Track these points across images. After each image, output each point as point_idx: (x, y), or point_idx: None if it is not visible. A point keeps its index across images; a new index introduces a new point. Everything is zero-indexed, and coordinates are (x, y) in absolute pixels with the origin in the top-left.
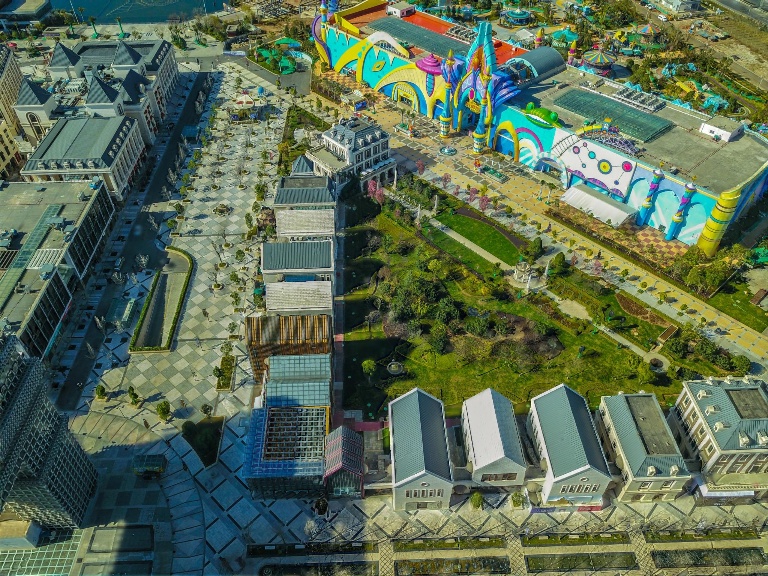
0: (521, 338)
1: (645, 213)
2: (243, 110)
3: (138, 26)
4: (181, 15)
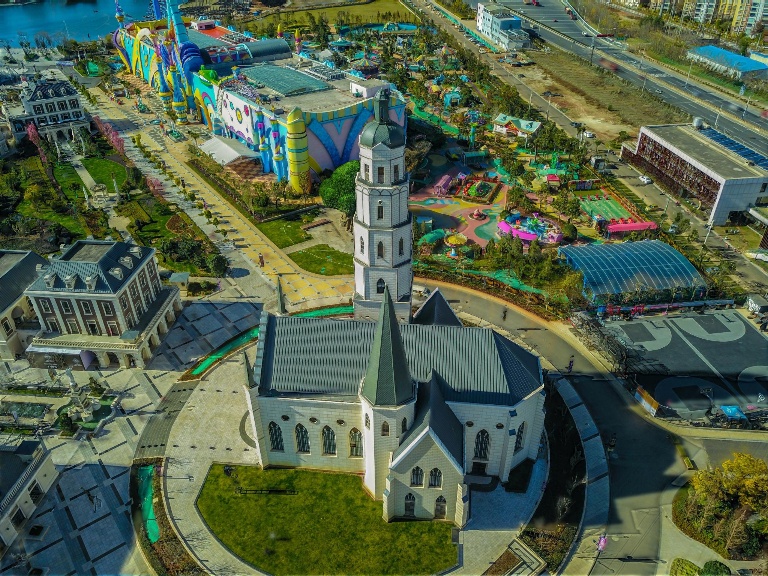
0: (37, 238)
1: (264, 158)
2: (12, 91)
3: (14, 49)
4: (47, 39)
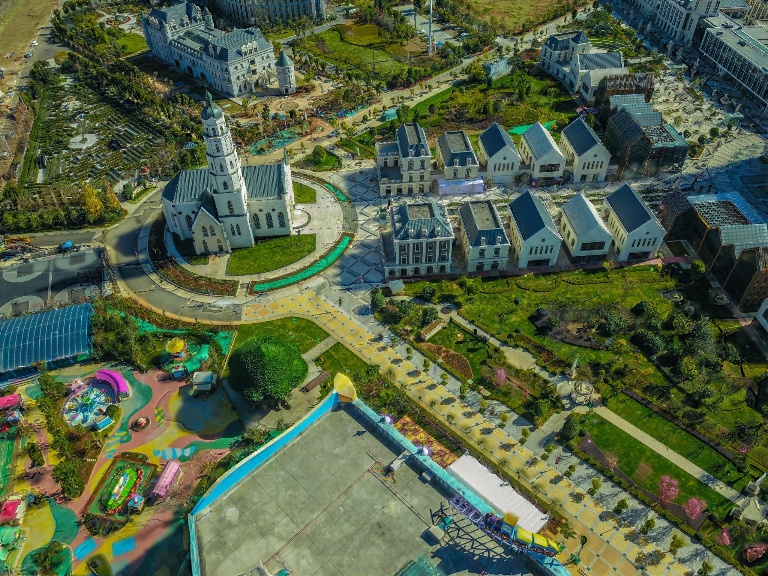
0: (570, 325)
1: None
2: None
3: None
4: None
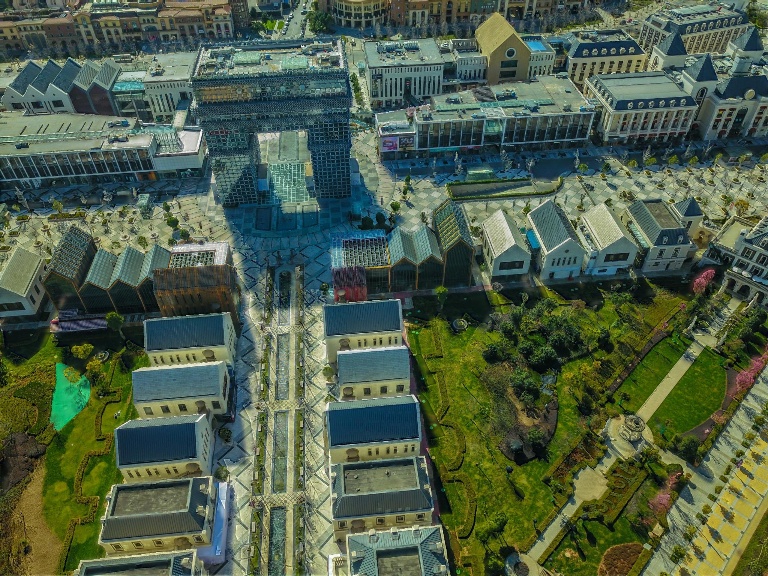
0: (523, 423)
1: None
2: None
3: None
4: None
